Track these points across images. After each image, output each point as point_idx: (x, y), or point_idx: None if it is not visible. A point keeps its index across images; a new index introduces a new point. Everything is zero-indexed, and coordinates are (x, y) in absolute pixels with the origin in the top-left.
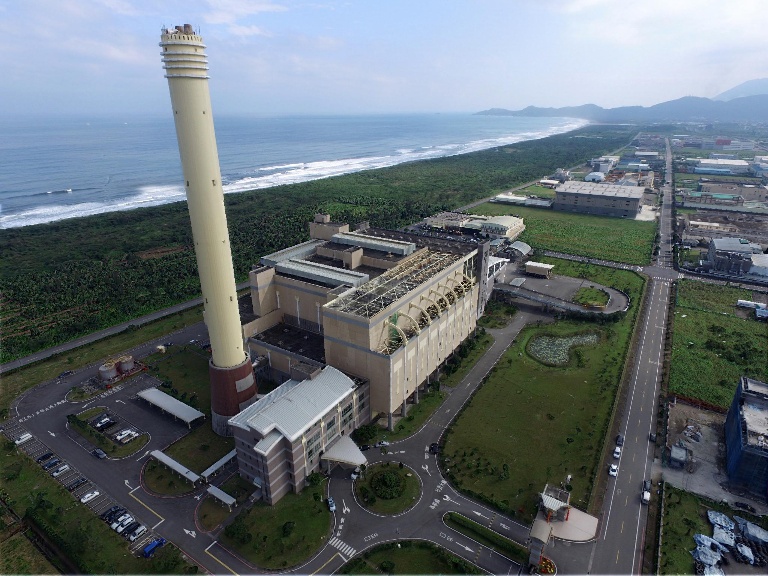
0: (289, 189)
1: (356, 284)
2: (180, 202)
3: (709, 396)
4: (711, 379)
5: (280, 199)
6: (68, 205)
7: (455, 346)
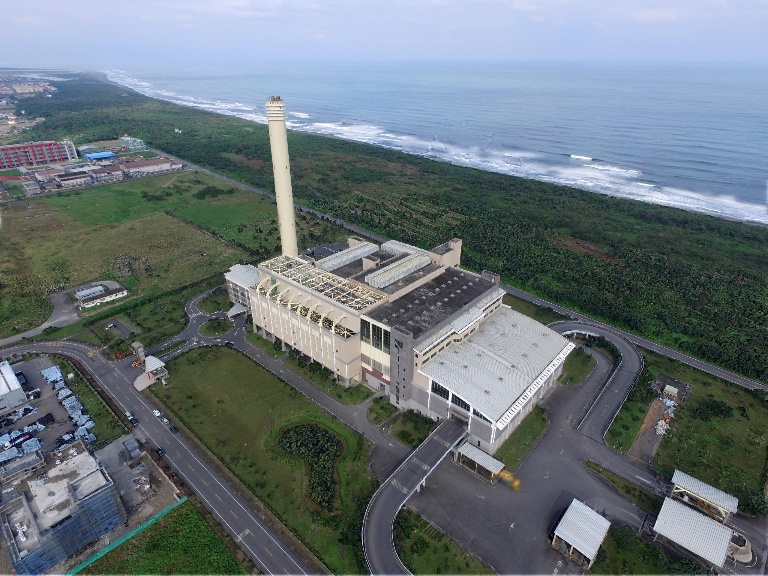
0: None
1: (318, 265)
2: (760, 228)
3: (161, 538)
4: (180, 572)
5: None
6: (649, 190)
7: (316, 358)
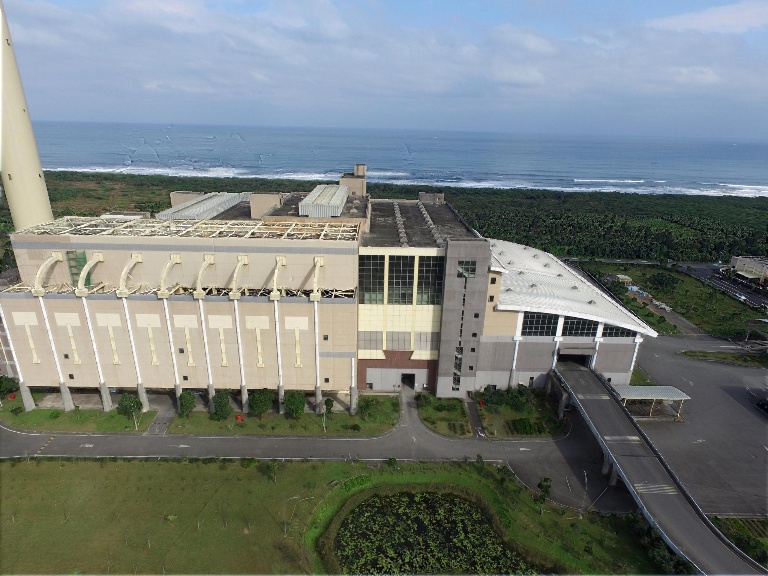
0: (626, 197)
1: (164, 218)
2: None
3: None
4: None
5: (592, 203)
6: (392, 173)
7: (256, 384)
